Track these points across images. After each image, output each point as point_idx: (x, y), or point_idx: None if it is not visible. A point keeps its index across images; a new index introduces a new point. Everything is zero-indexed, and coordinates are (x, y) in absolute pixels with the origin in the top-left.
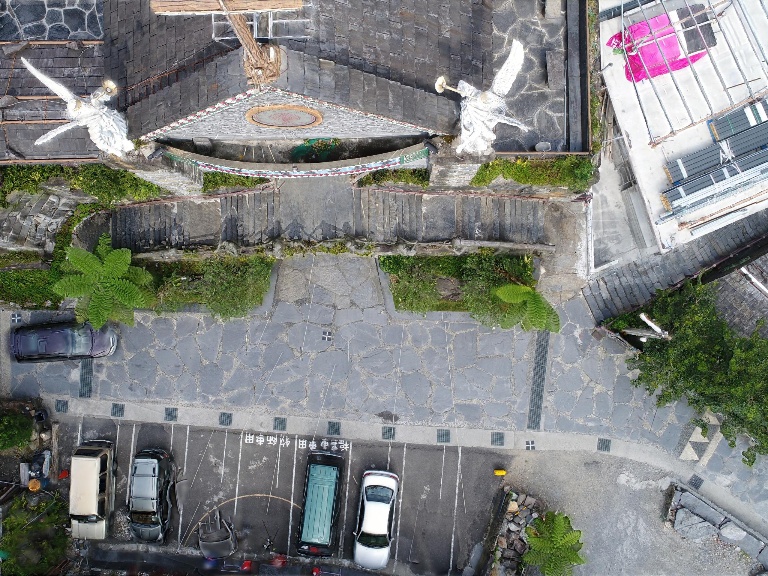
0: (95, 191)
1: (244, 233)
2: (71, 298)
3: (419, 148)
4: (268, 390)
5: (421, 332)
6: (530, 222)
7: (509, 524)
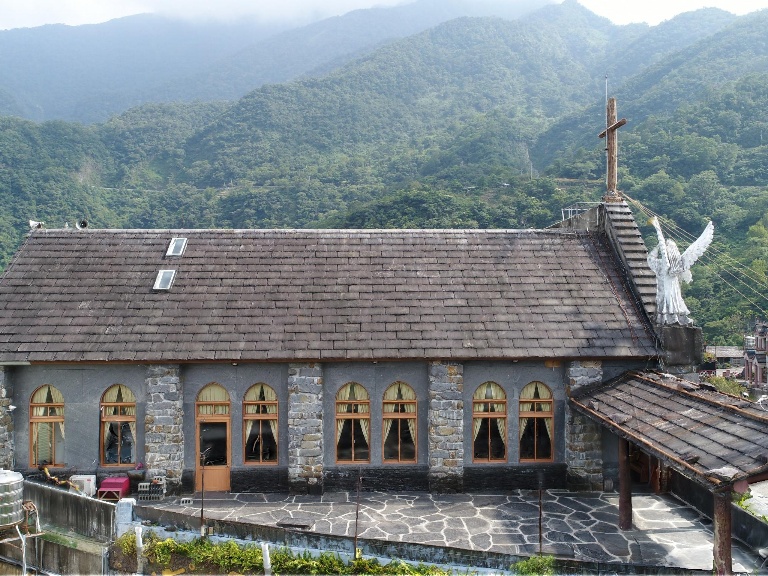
0: None
1: None
2: None
3: None
4: None
5: None
6: None
7: None
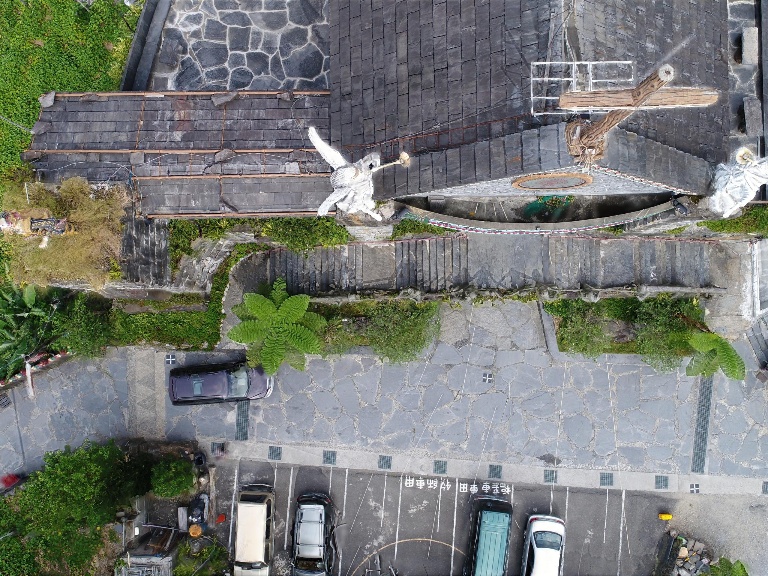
0: (289, 240)
1: (424, 279)
2: (227, 339)
3: (665, 208)
4: (428, 433)
5: (583, 374)
6: (697, 264)
7: (680, 570)
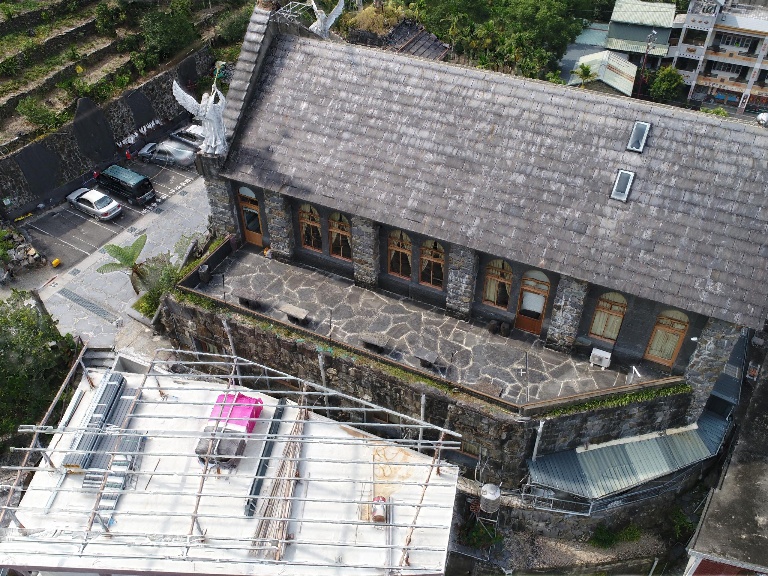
0: None
1: None
2: None
3: None
4: None
5: (172, 262)
6: None
7: None
